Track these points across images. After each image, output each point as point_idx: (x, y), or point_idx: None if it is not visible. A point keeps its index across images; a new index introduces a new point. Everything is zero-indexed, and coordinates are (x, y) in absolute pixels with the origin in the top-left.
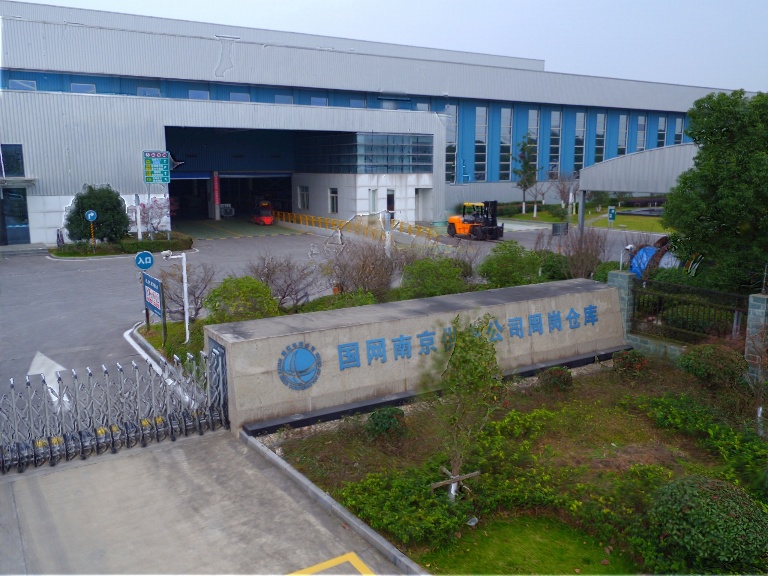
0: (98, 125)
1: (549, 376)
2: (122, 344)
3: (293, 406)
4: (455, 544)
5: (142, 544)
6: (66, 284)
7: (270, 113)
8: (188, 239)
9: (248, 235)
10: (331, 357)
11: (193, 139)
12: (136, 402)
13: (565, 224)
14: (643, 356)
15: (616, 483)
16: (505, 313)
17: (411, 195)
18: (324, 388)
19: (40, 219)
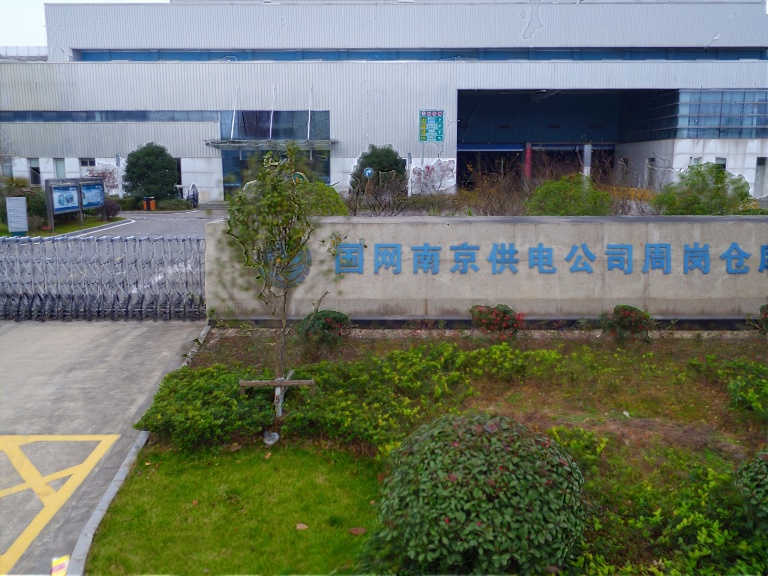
0: (395, 91)
1: (612, 317)
2: None
3: None
4: (213, 454)
5: None
6: None
7: (572, 71)
8: None
9: None
10: (325, 256)
11: (508, 109)
12: None
13: None
14: None
15: None
16: (602, 236)
17: (750, 165)
18: (312, 291)
19: (340, 179)
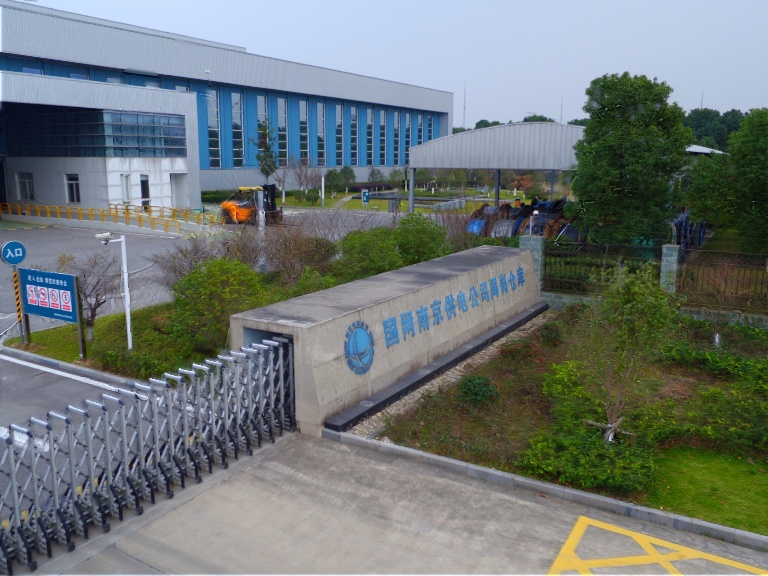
0: None
1: (545, 331)
2: (2, 364)
3: (358, 393)
4: (654, 485)
5: (381, 567)
6: None
7: None
8: None
9: None
10: (379, 335)
11: None
12: (209, 414)
13: (398, 201)
14: None
15: (710, 407)
16: (477, 278)
17: (166, 181)
18: (378, 369)
19: None
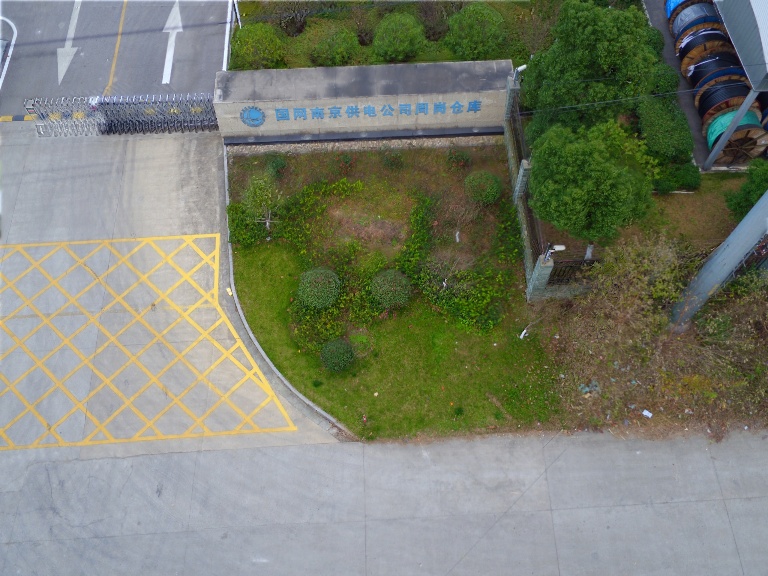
0: None
1: None
2: (224, 3)
3: (250, 133)
4: (253, 247)
5: (156, 199)
6: None
7: None
8: None
9: None
10: (271, 114)
11: None
12: None
13: None
14: (464, 159)
15: (330, 248)
16: (397, 101)
17: None
18: (268, 127)
19: None
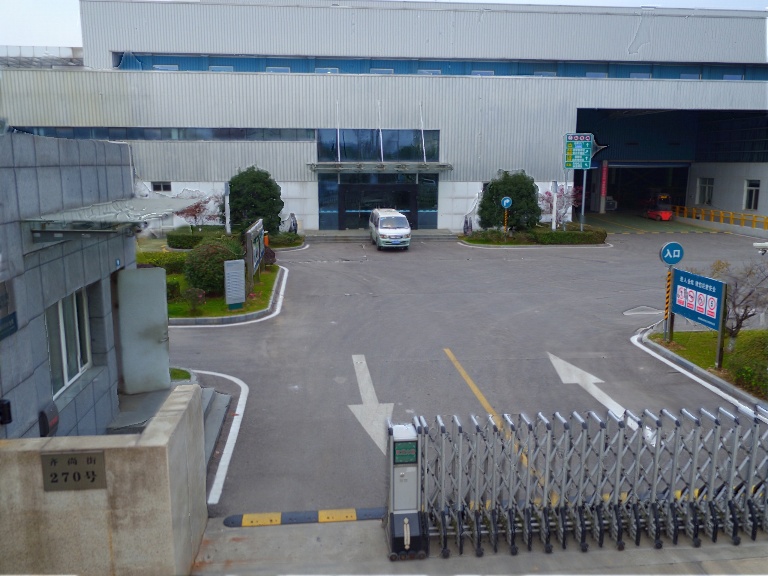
0: (511, 109)
1: None
2: (642, 355)
3: None
4: None
5: None
6: (505, 273)
7: (695, 91)
8: (604, 232)
9: (653, 231)
10: None
11: None
12: None
13: None
14: None
15: None
16: None
17: None
18: None
19: (448, 205)
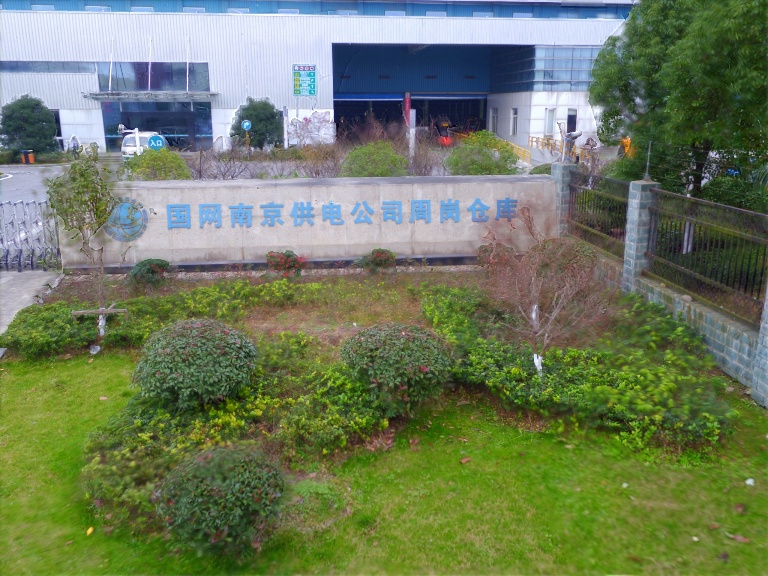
0: (272, 43)
1: None
2: None
3: (117, 255)
4: (51, 361)
5: None
6: None
7: (439, 27)
8: None
9: None
10: (159, 215)
11: (387, 60)
12: None
13: None
14: (509, 251)
15: None
16: (379, 195)
17: None
18: (149, 243)
19: (221, 130)
